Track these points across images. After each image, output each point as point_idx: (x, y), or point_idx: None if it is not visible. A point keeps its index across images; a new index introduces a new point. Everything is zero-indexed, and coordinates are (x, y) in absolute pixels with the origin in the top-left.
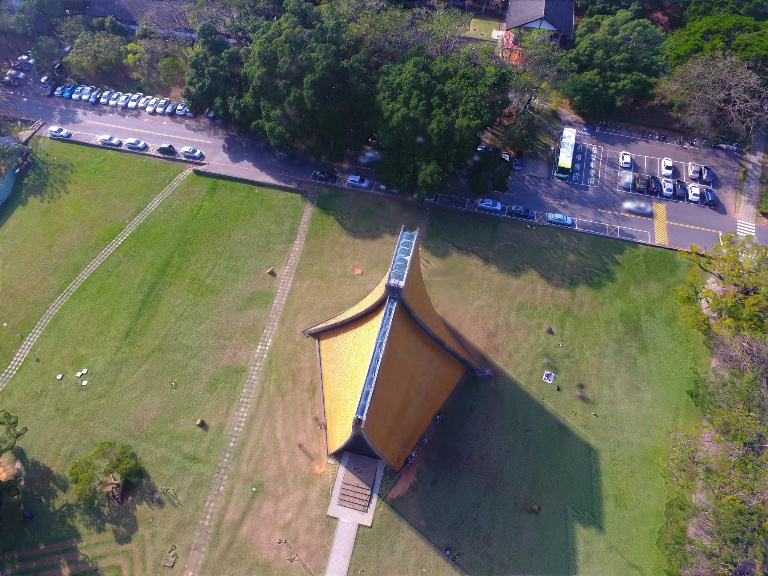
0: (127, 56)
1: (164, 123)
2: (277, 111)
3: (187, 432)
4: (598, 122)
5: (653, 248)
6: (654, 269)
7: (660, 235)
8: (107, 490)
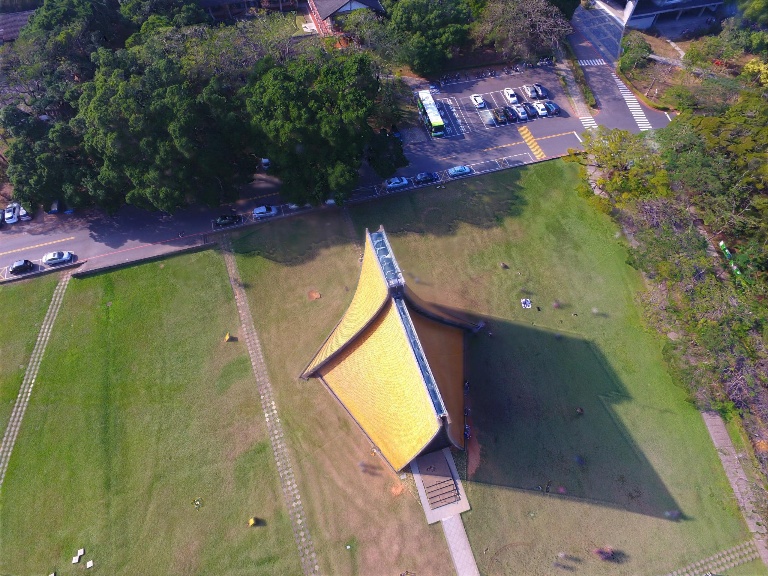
0: None
1: None
2: (151, 173)
3: (245, 539)
4: (439, 77)
5: (538, 164)
6: (548, 180)
7: (537, 152)
8: None
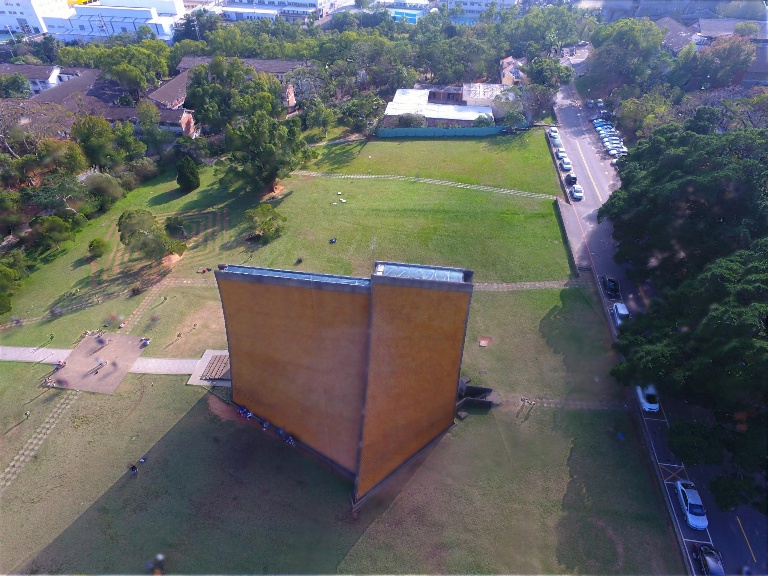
0: (648, 115)
1: (606, 173)
2: None
3: (293, 256)
4: None
5: None
6: None
7: None
8: (257, 232)
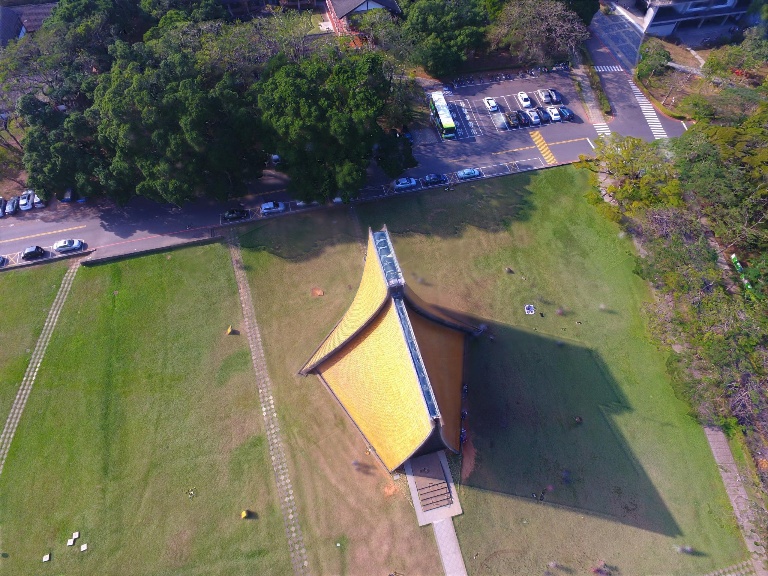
0: None
1: (11, 226)
2: (161, 165)
3: (237, 531)
4: (452, 79)
5: (549, 170)
6: (558, 186)
7: (548, 157)
8: None
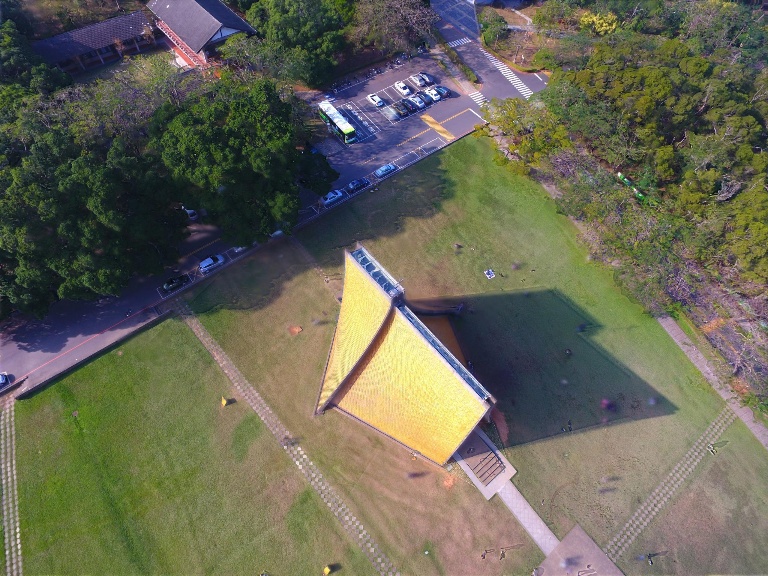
0: None
1: None
2: (81, 259)
3: None
4: (330, 86)
5: (451, 146)
6: (465, 158)
7: (446, 135)
8: None
